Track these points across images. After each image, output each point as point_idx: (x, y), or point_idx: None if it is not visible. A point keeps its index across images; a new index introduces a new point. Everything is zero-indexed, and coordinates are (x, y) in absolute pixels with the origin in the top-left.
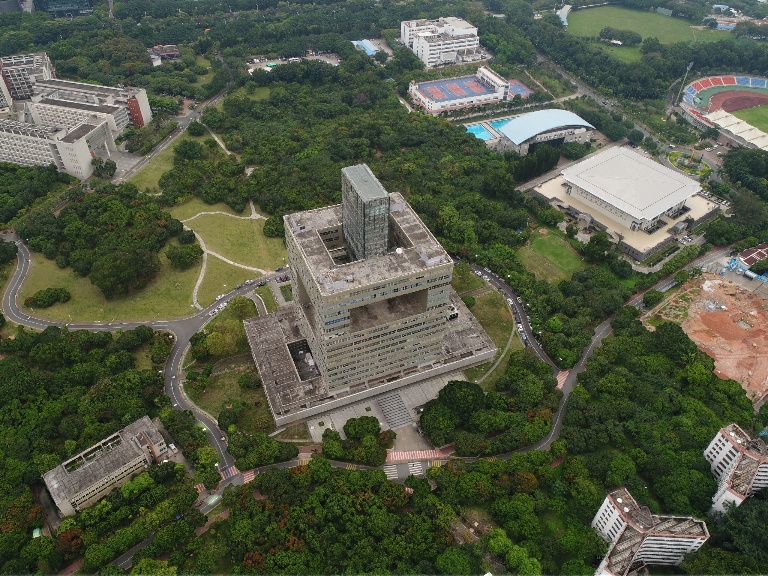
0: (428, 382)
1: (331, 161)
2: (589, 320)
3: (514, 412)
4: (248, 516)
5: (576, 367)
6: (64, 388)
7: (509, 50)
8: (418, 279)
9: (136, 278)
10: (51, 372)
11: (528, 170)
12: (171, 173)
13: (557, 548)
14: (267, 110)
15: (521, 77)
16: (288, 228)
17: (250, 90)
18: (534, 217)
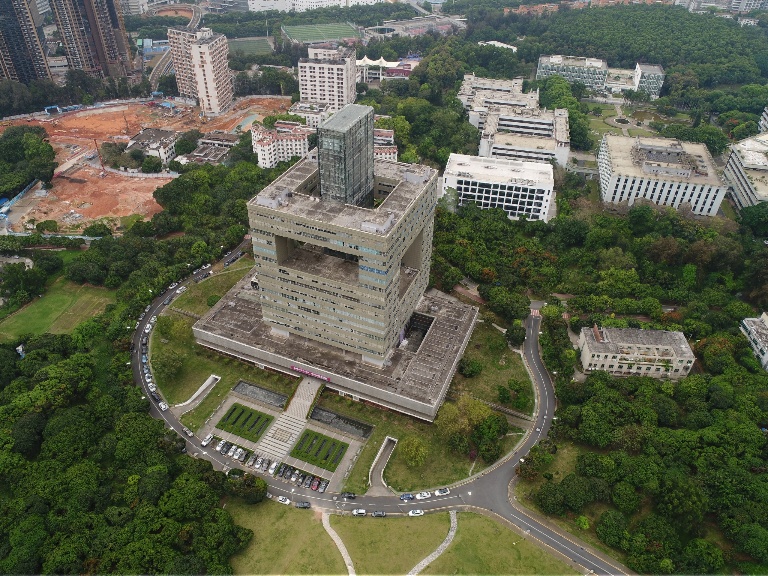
0: None
1: None
2: None
3: None
4: None
5: None
6: None
7: None
8: None
9: None
10: None
11: None
12: None
13: None
14: None
15: None
16: None
17: None
18: None
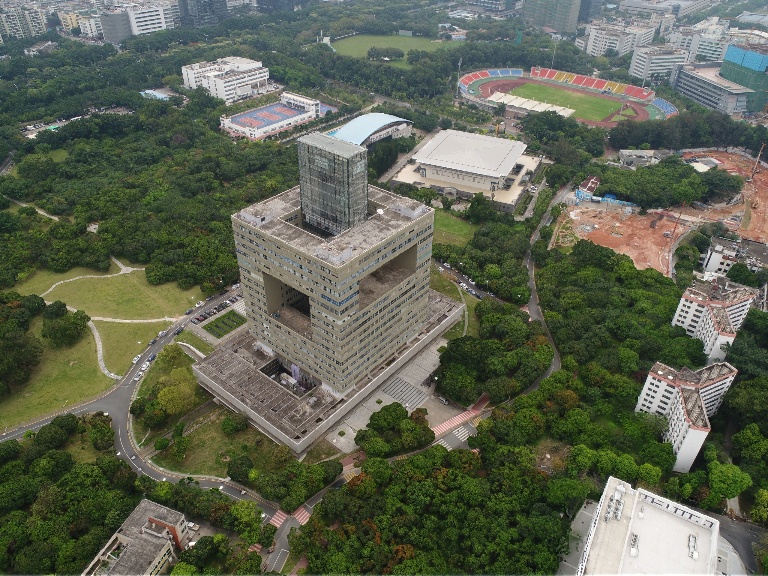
0: (418, 357)
1: (184, 198)
2: (515, 261)
3: None
4: (335, 550)
5: (530, 301)
6: None
7: (299, 76)
8: (410, 233)
9: (17, 369)
10: None
11: (379, 165)
12: None
13: (630, 440)
14: (79, 167)
15: (320, 98)
16: (245, 224)
17: None
18: None
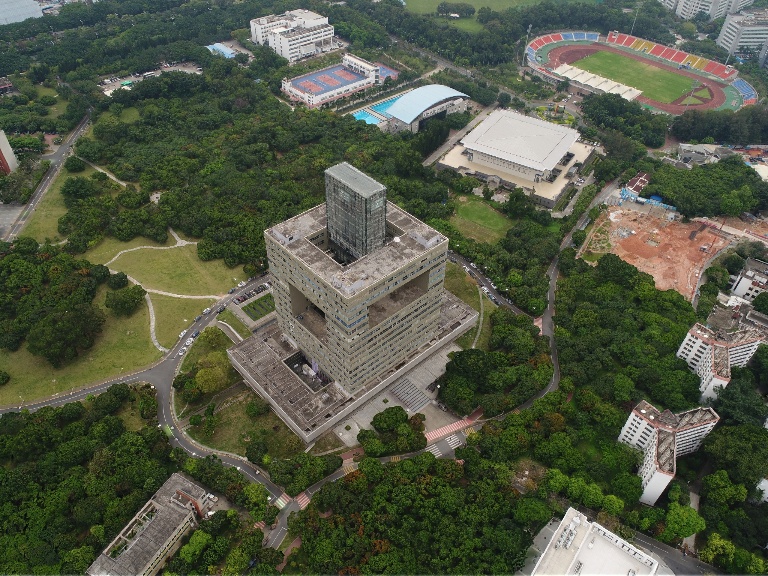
0: (428, 360)
1: (239, 171)
2: (540, 268)
3: (517, 365)
4: (324, 536)
5: (545, 312)
6: (58, 474)
7: (364, 35)
8: (422, 262)
9: (84, 337)
10: (35, 462)
11: (428, 146)
12: (68, 217)
13: (604, 469)
14: (147, 131)
15: (382, 60)
16: (275, 242)
17: (117, 113)
18: (449, 188)
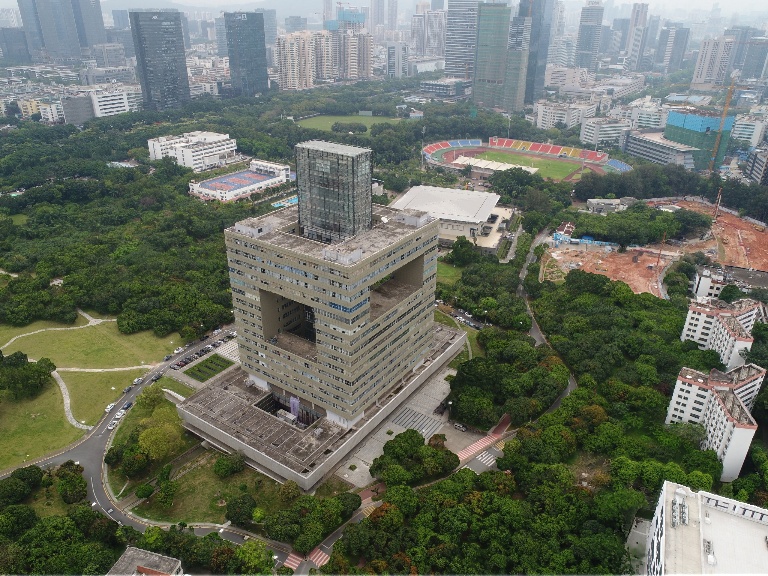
0: (425, 387)
1: None
2: None
3: None
4: None
5: (531, 330)
6: None
7: (267, 147)
8: (417, 241)
9: None
10: None
11: None
12: None
13: (669, 451)
14: (41, 227)
15: None
16: (241, 236)
17: None
18: None
